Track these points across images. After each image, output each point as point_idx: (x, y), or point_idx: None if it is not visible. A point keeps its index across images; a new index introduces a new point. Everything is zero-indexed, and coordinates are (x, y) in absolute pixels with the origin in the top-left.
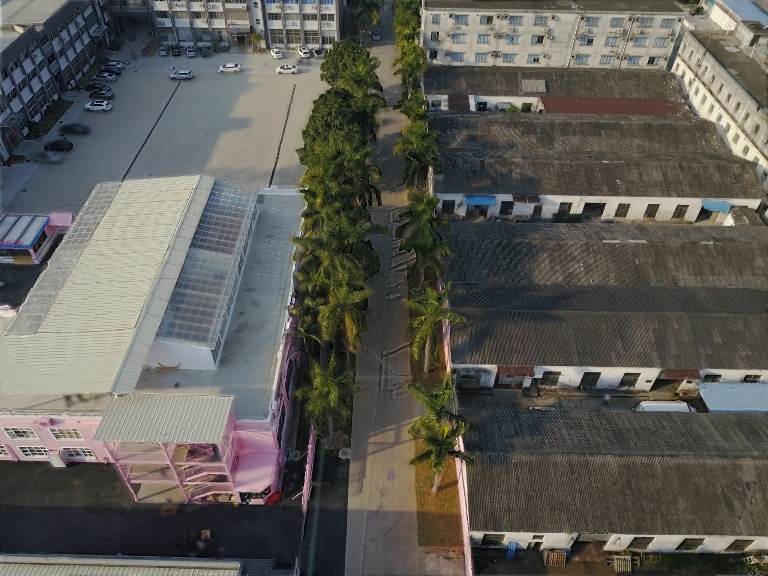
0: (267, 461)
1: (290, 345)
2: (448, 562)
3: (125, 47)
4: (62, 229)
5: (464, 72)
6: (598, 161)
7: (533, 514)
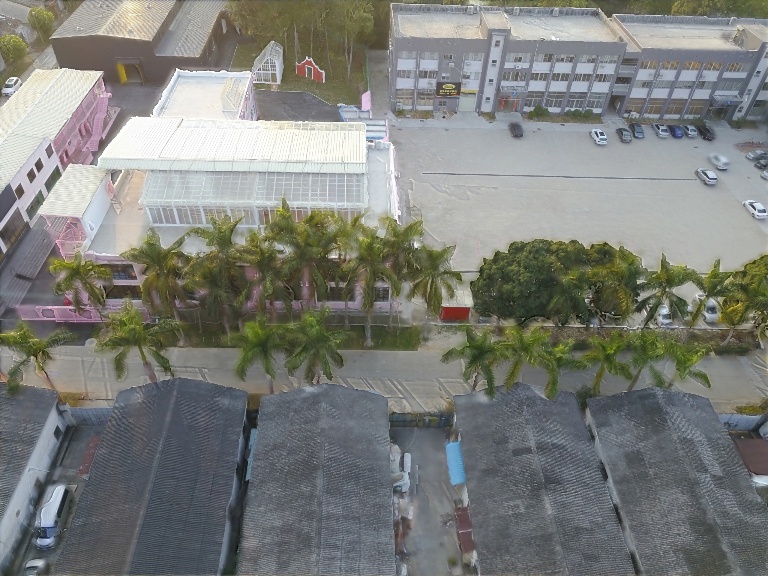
0: None
1: None
2: None
3: (747, 131)
4: None
5: None
6: None
7: None
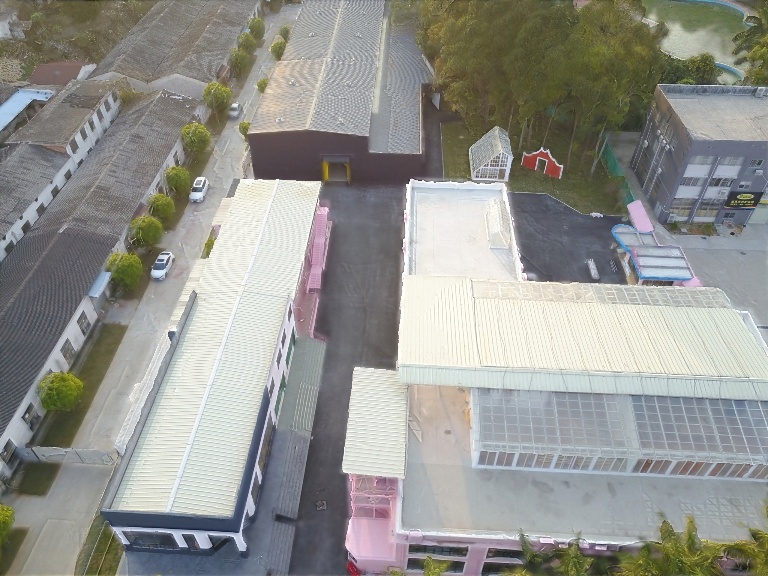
0: (381, 549)
1: None
2: None
3: None
4: None
5: None
6: None
7: None
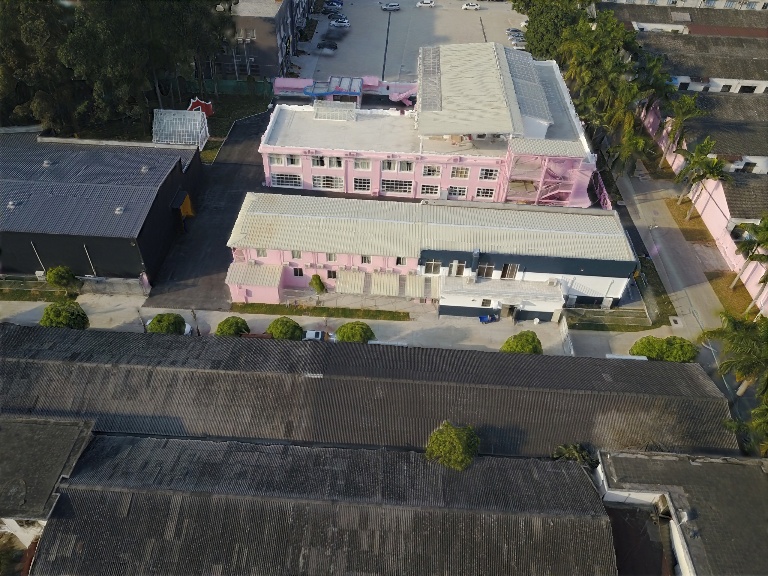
0: (584, 195)
1: (585, 135)
2: (708, 248)
3: None
4: (366, 90)
5: (626, 6)
6: (750, 58)
7: (767, 211)
